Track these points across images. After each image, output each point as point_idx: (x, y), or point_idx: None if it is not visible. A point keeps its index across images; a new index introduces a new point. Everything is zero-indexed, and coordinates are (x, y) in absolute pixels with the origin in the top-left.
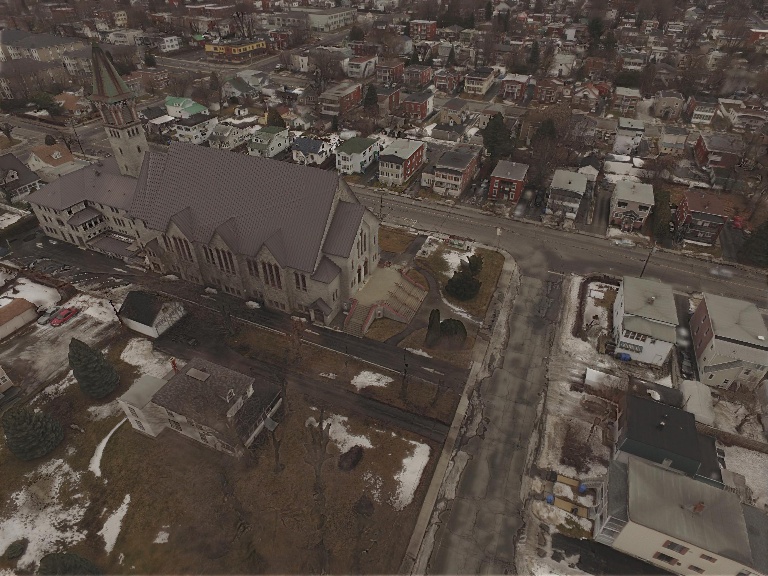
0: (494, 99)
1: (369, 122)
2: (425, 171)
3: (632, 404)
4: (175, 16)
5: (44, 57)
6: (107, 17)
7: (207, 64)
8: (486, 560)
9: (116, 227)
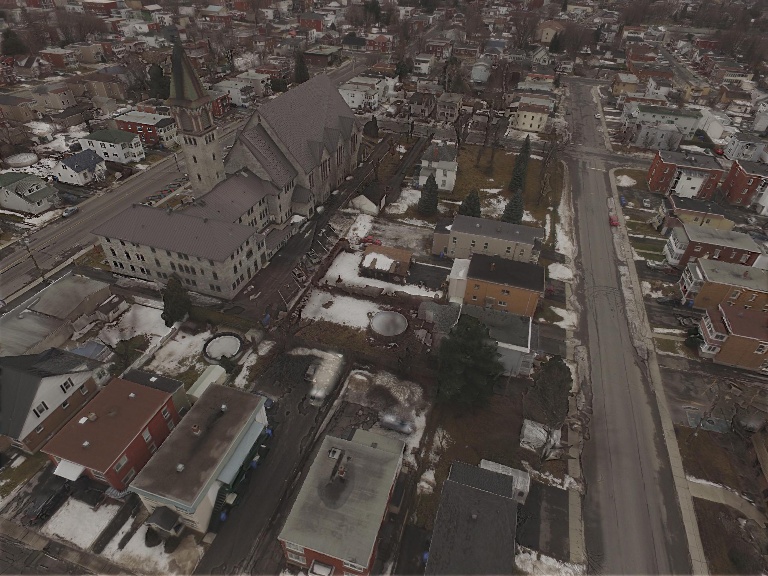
0: None
1: (5, 143)
2: None
3: None
4: None
5: None
6: None
7: None
8: None
9: None
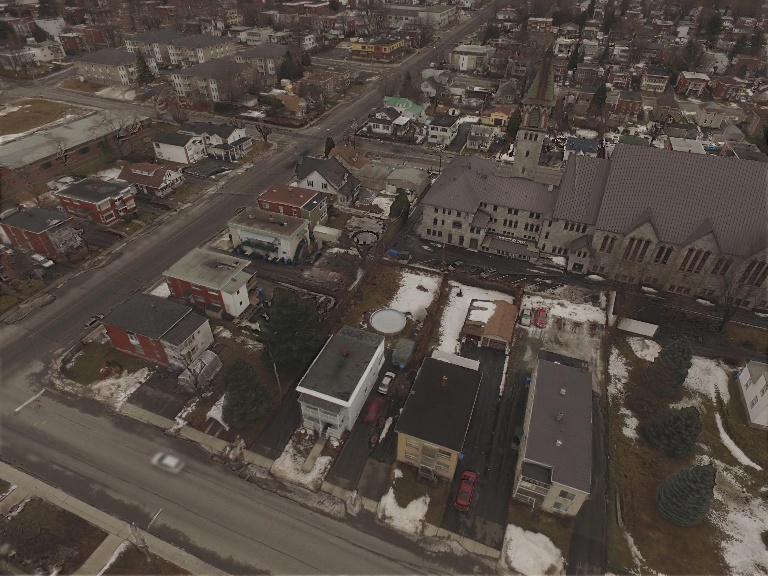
0: (677, 97)
1: (598, 121)
2: None
3: None
4: (289, 14)
5: (207, 57)
6: (219, 15)
7: (358, 63)
8: None
9: (501, 229)
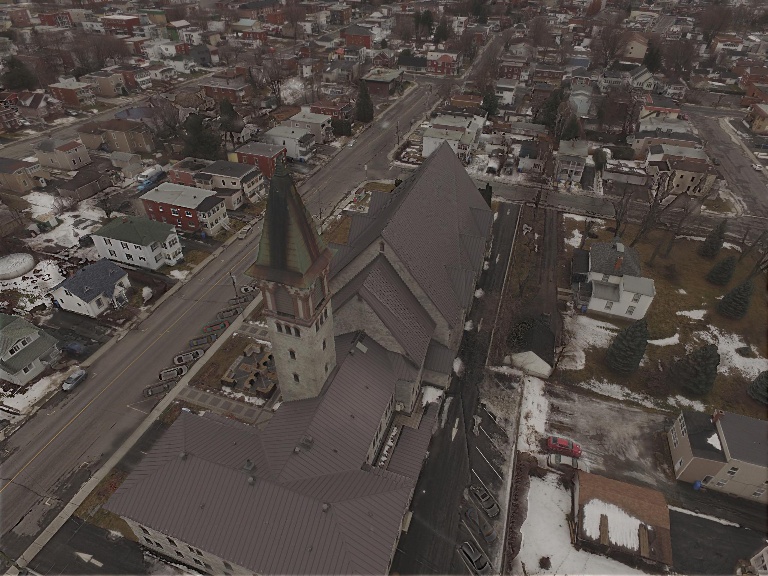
0: None
1: None
2: (227, 195)
3: (528, 148)
4: None
5: None
6: None
7: None
8: (607, 204)
9: None
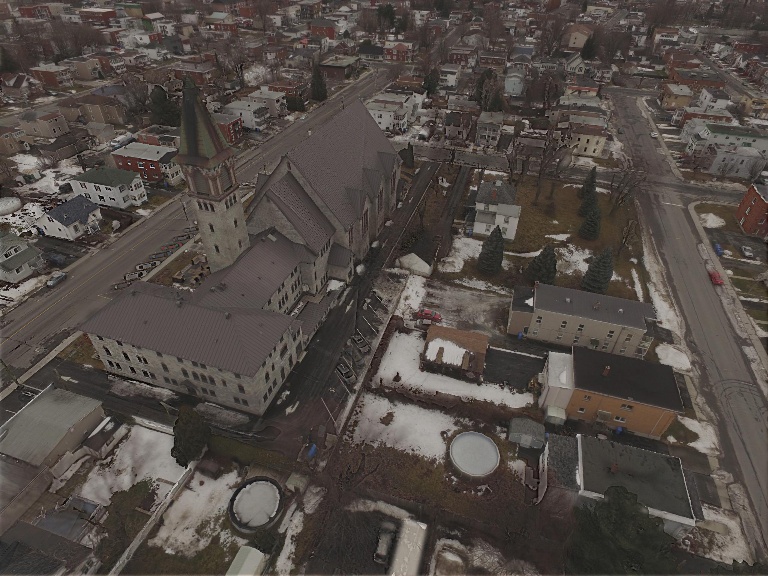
0: None
1: None
2: None
3: None
4: None
5: None
6: None
7: None
8: None
9: None
